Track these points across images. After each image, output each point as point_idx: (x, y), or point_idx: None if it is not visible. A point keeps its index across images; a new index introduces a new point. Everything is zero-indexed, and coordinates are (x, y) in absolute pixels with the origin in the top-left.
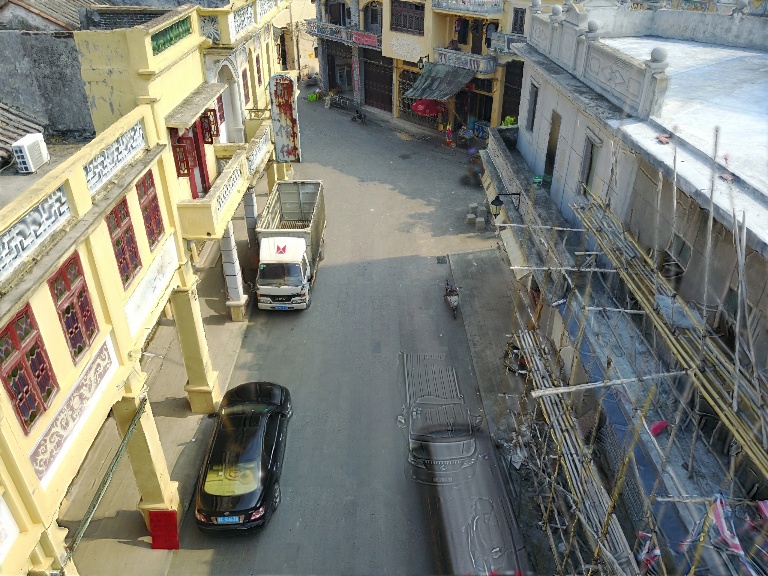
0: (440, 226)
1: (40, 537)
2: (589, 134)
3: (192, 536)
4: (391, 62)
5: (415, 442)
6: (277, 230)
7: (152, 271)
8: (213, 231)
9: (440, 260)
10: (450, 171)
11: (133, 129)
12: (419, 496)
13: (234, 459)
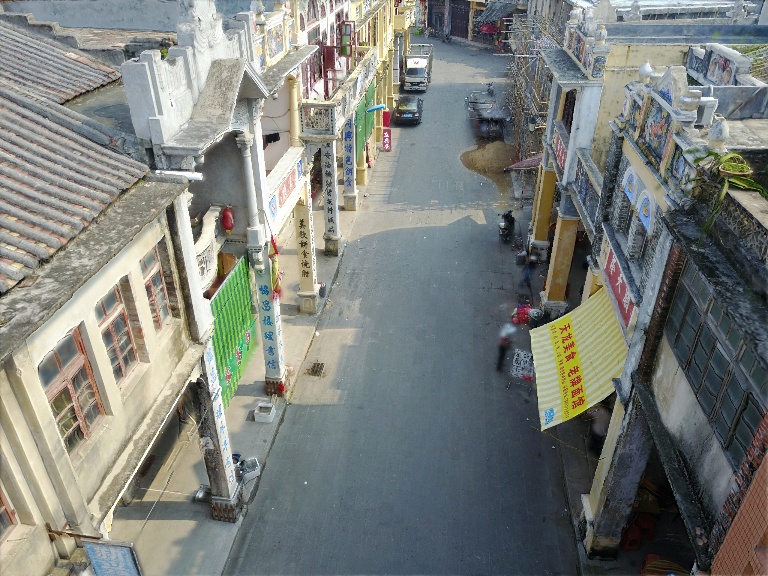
0: (489, 76)
1: (381, 64)
2: None
3: None
4: (469, 6)
5: (471, 103)
6: (415, 55)
7: None
8: (404, 27)
9: None
10: (499, 60)
11: None
12: (471, 124)
13: None
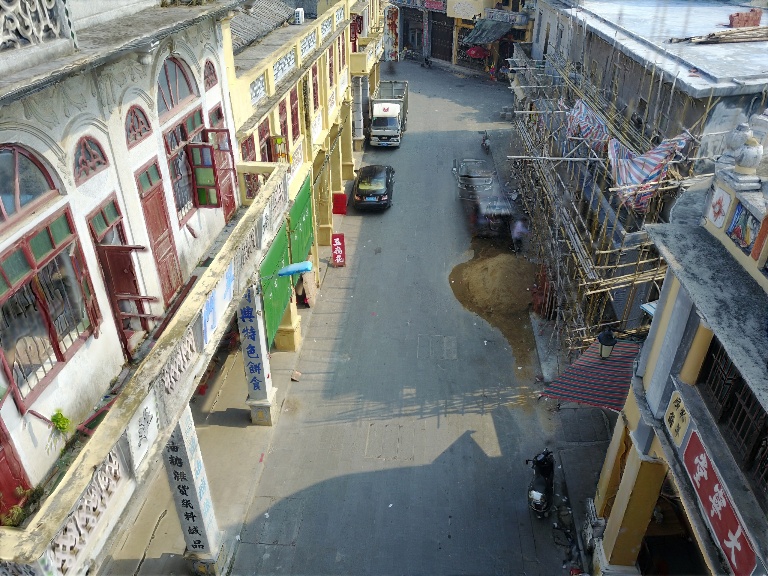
0: (482, 118)
1: None
2: (559, 25)
3: (351, 213)
4: (453, 23)
5: (461, 177)
6: (384, 99)
7: (342, 79)
8: (365, 69)
9: (480, 132)
10: (492, 93)
11: (342, 8)
12: (462, 206)
13: (372, 178)
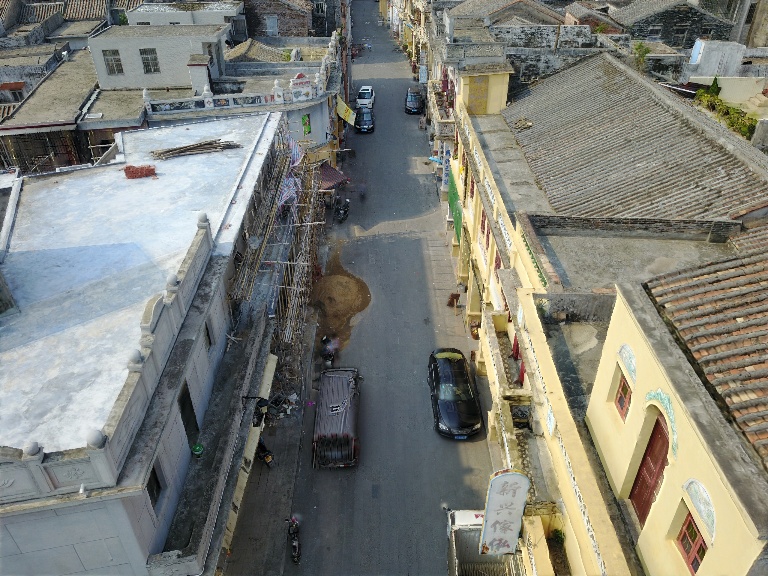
0: None
1: None
2: None
3: None
4: None
5: (354, 370)
6: None
7: None
8: None
9: None
10: None
11: None
12: None
13: None
